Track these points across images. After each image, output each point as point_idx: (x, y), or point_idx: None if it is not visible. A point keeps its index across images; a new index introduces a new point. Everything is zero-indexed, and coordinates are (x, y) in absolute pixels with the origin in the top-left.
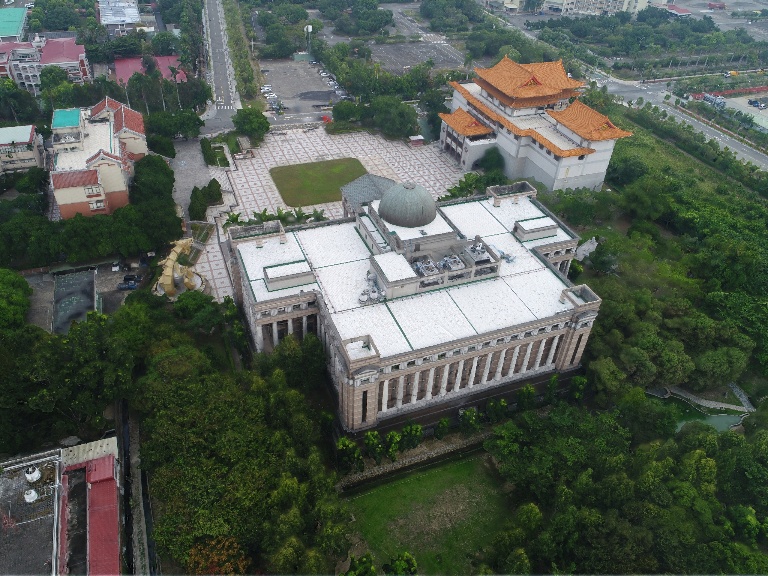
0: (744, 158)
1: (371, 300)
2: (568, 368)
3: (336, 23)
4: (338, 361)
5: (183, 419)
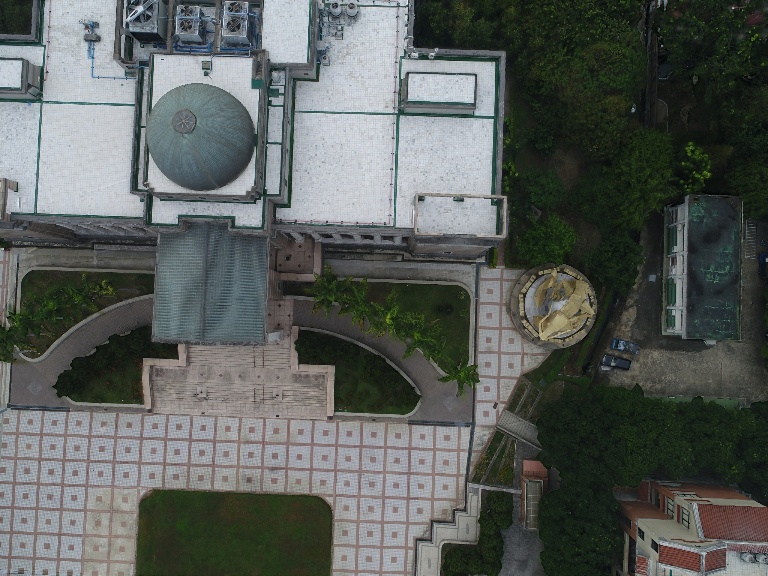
0: None
1: None
2: None
3: None
4: None
5: None
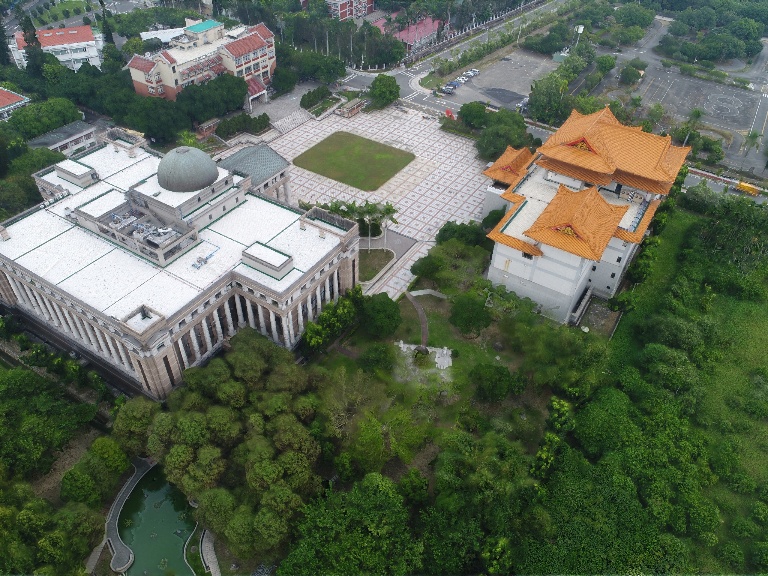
0: None
1: None
2: None
3: (663, 38)
4: None
5: None
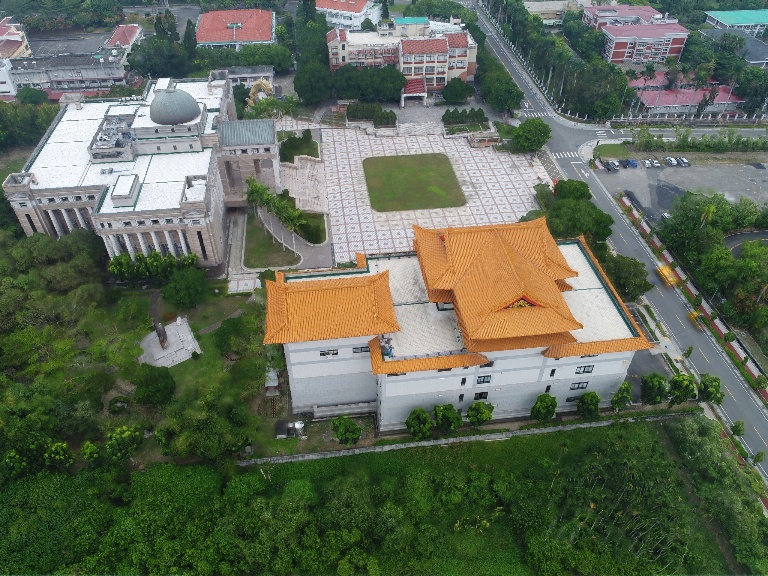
0: None
1: None
2: None
3: None
4: None
5: None
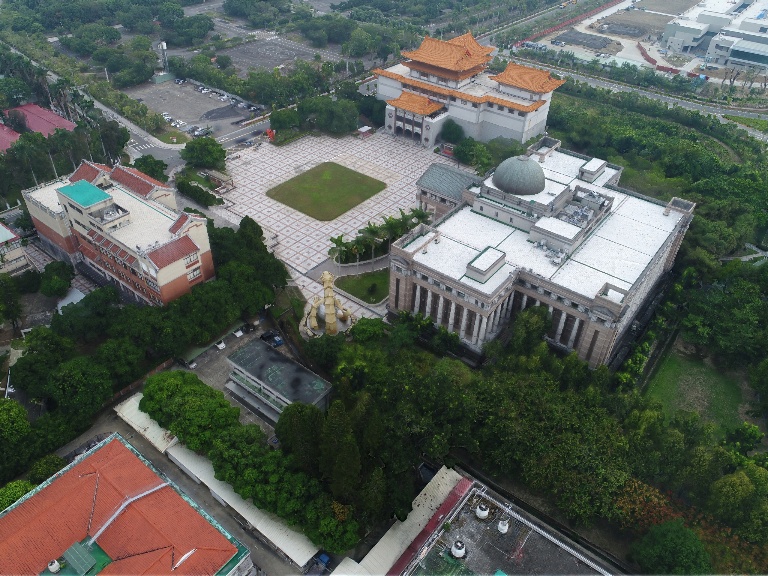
0: (591, 86)
1: (561, 260)
2: (670, 266)
3: (161, 36)
4: (593, 313)
5: (513, 414)
